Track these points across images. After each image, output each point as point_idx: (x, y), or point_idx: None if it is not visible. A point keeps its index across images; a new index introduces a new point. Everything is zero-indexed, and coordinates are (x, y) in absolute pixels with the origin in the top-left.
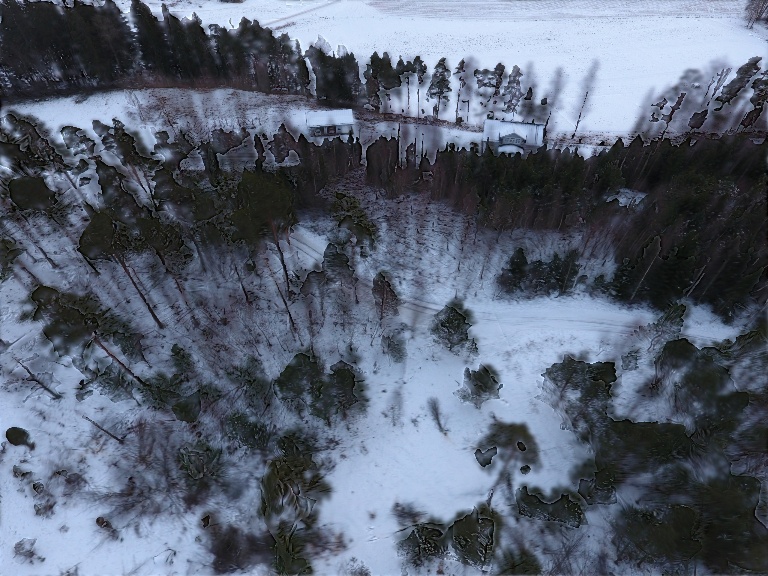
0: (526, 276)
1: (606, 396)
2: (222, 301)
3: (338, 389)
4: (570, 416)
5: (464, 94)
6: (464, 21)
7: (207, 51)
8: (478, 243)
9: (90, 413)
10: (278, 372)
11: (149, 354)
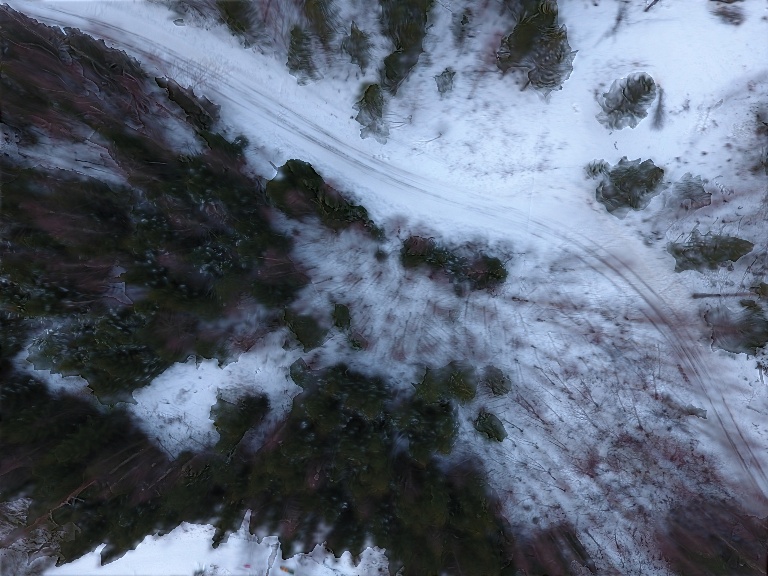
0: None
1: None
2: None
3: None
4: None
5: None
6: None
7: None
8: None
9: None
10: None
11: None
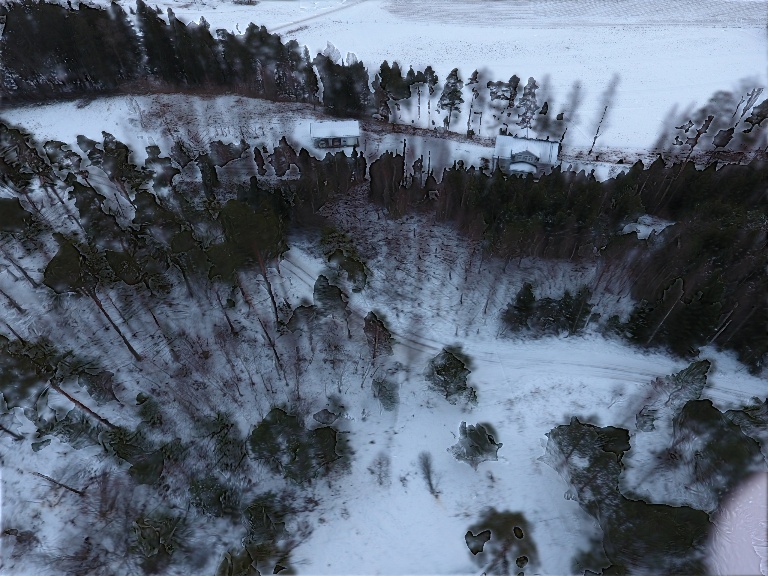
0: (533, 314)
1: (618, 470)
2: (206, 331)
3: (316, 450)
4: (576, 486)
5: (477, 104)
6: (481, 27)
7: (213, 57)
8: (483, 272)
9: (52, 458)
10: (259, 416)
11: (123, 390)
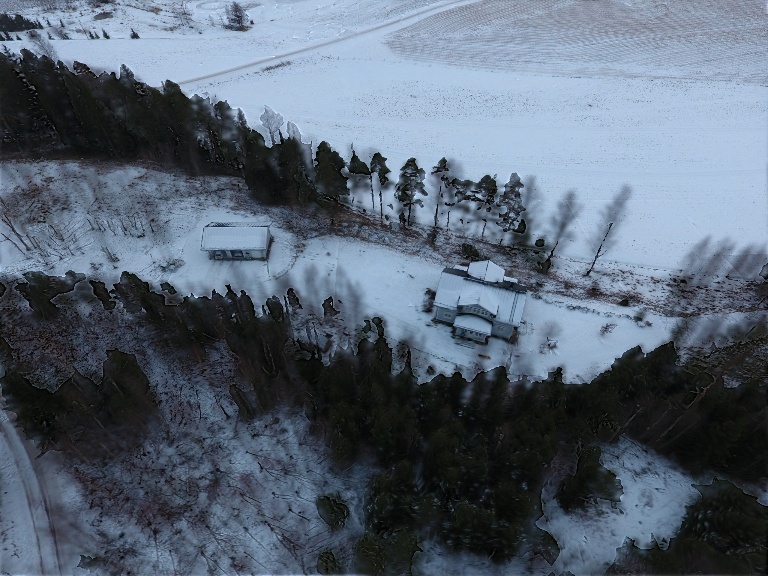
0: None
1: None
2: None
3: None
4: None
5: None
6: (491, 72)
7: (117, 120)
8: None
9: None
10: None
11: None
